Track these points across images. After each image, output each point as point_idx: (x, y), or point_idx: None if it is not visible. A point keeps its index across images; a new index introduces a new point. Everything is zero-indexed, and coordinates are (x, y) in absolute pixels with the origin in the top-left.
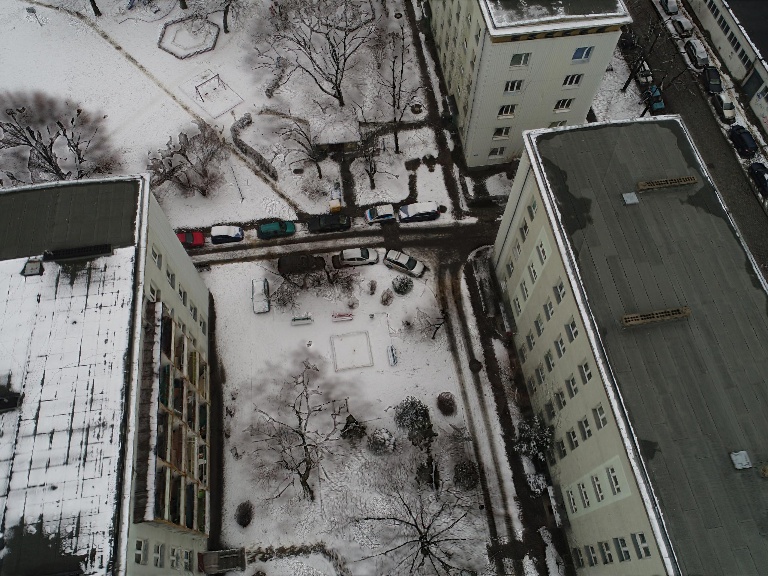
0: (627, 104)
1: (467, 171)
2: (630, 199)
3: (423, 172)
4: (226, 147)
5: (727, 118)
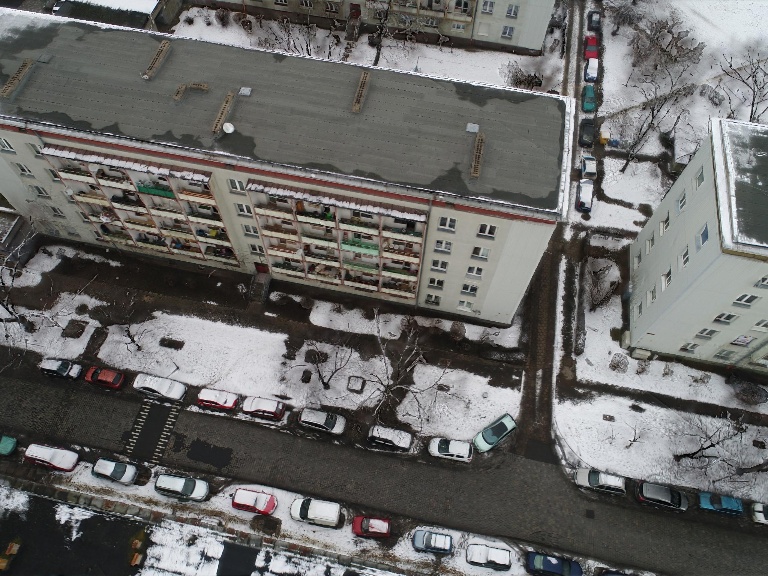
0: None
1: None
2: (472, 127)
3: (635, 215)
4: (673, 60)
5: None
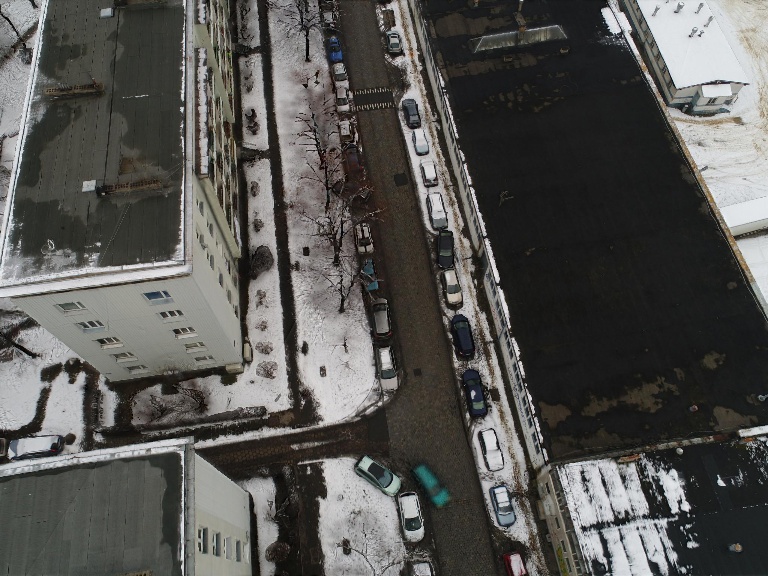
0: (336, 283)
1: (114, 383)
2: None
3: (60, 384)
4: None
5: (451, 303)
